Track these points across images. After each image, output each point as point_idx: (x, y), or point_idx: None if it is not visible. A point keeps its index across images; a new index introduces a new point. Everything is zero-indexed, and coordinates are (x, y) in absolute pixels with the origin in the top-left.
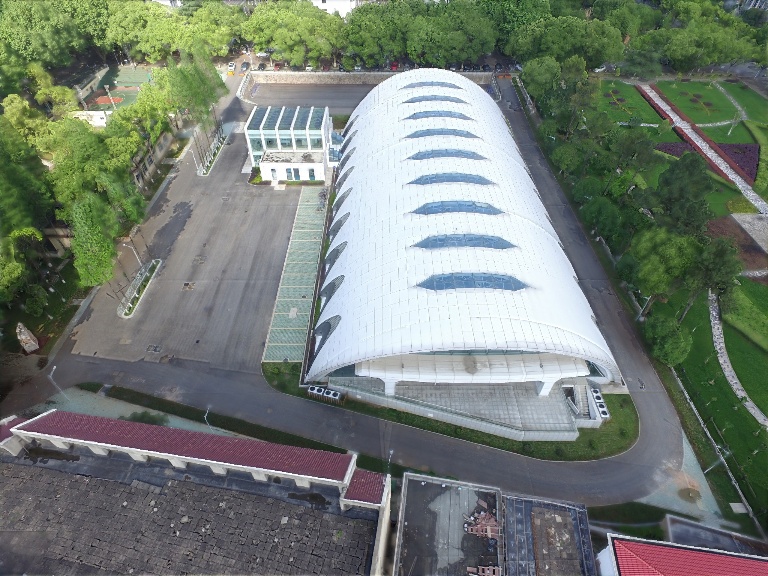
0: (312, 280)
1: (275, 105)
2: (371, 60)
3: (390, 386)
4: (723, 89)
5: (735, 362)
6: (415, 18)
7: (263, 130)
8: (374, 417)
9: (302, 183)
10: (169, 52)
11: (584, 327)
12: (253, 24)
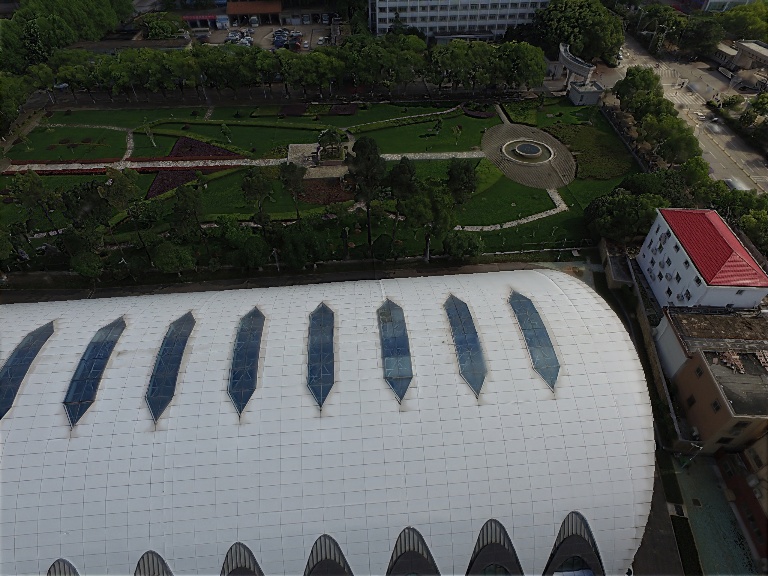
0: None
1: None
2: None
3: None
4: (60, 124)
5: None
6: None
7: None
8: None
9: None
10: None
11: None
12: None
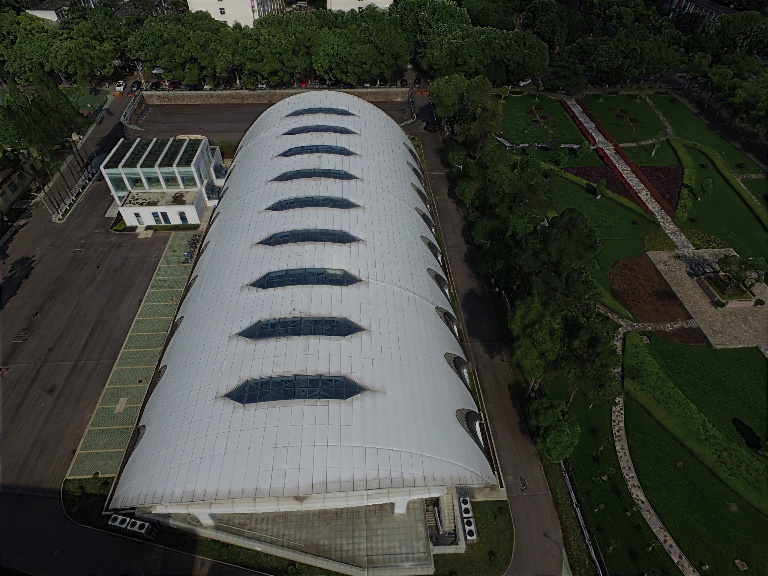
0: (155, 358)
1: (164, 131)
2: (275, 77)
3: (204, 517)
4: (652, 102)
5: (634, 448)
6: (322, 30)
7: (123, 169)
8: (189, 554)
9: (173, 228)
10: (53, 70)
11: (436, 437)
12: (136, 40)
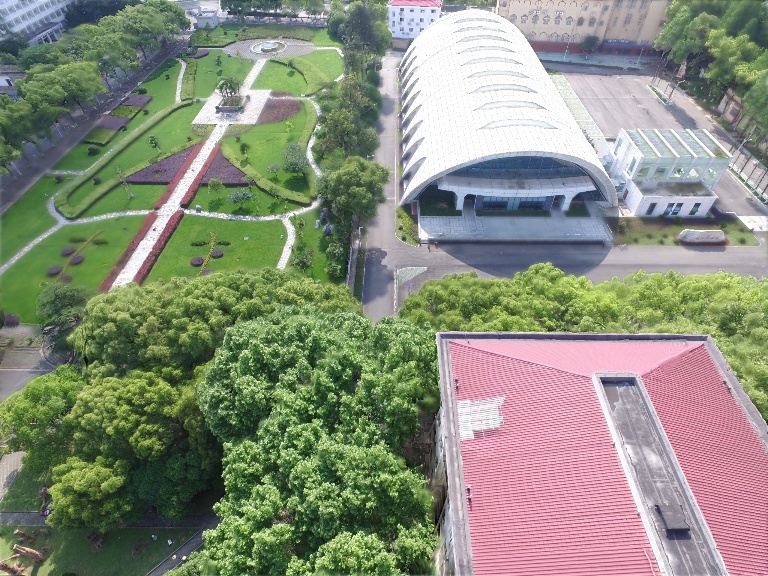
0: None
1: None
2: None
3: None
4: None
5: (341, 73)
6: None
7: None
8: None
9: None
10: None
11: None
12: None
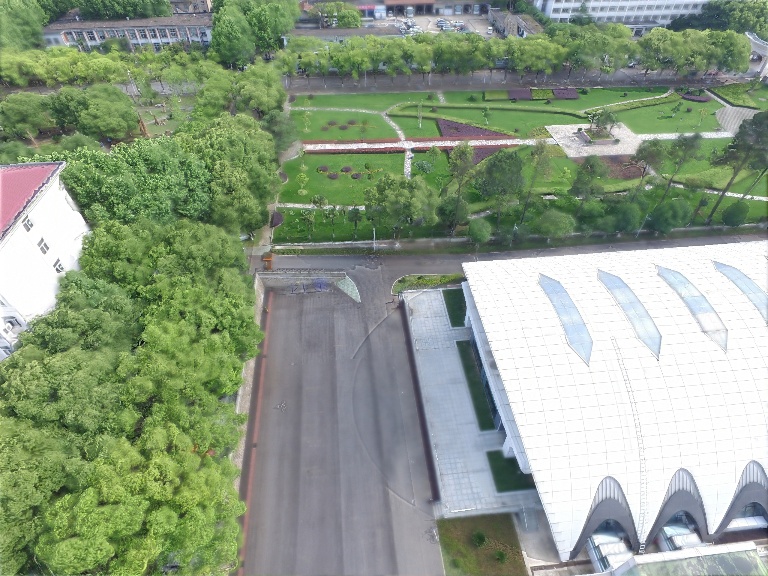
0: None
1: None
2: None
3: None
4: (311, 108)
5: (762, 195)
6: (114, 349)
7: None
8: None
9: None
10: None
11: None
12: None
